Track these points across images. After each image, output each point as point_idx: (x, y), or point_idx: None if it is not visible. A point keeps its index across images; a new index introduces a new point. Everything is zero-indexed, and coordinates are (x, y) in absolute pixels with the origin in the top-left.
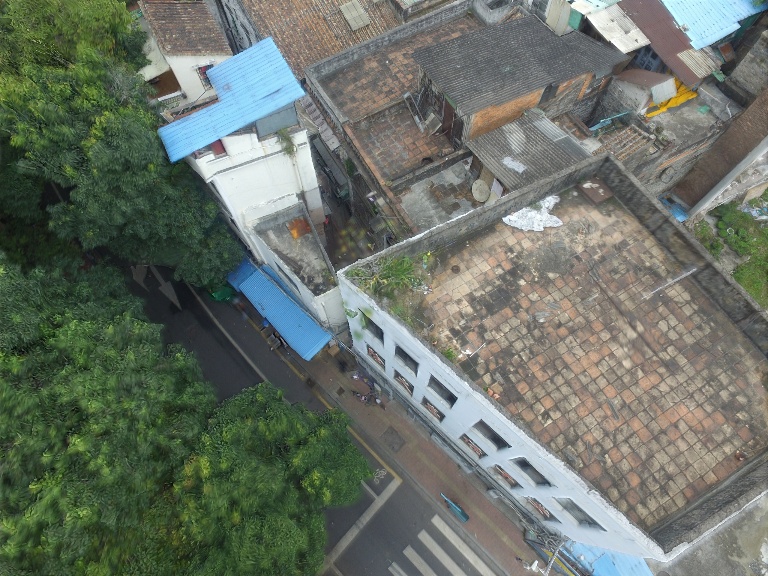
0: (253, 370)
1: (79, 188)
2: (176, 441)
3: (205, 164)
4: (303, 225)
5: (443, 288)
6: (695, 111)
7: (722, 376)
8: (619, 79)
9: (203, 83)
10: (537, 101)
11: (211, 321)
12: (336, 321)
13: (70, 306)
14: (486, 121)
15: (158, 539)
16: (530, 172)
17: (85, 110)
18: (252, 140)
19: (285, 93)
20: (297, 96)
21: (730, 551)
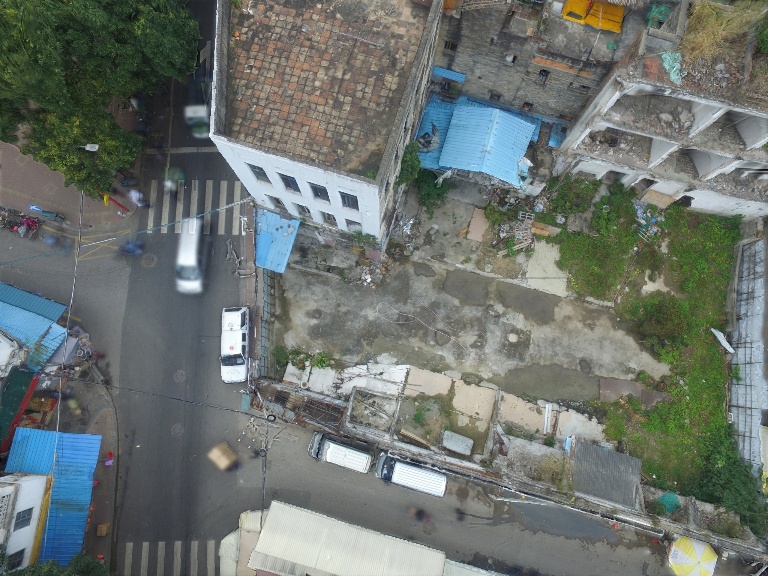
0: None
1: None
2: None
3: None
4: None
5: None
6: (604, 42)
7: (356, 131)
8: None
9: None
10: None
11: None
12: None
13: None
14: None
15: None
16: None
17: None
18: None
19: None
20: None
21: (366, 338)
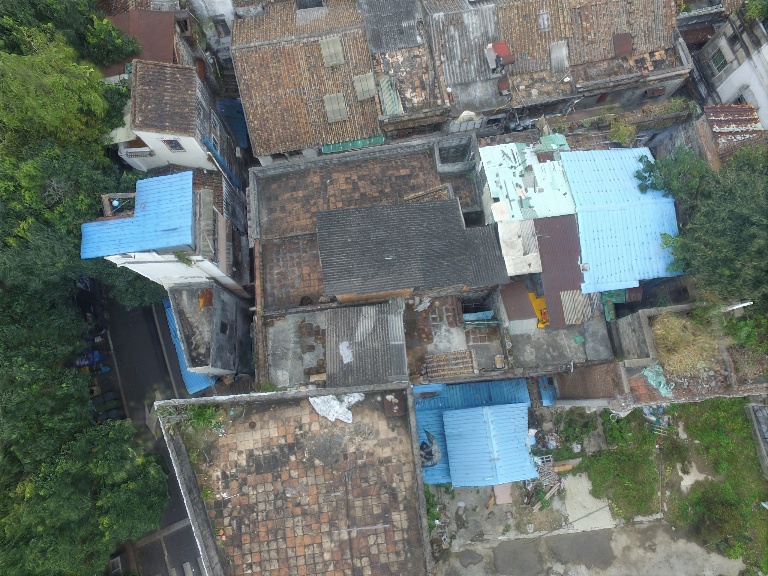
0: (166, 369)
1: None
2: (25, 461)
3: (114, 258)
4: (210, 297)
5: (235, 437)
6: (570, 337)
7: None
8: (500, 292)
9: (169, 148)
10: (410, 290)
11: (152, 314)
12: (221, 373)
13: (5, 318)
14: (354, 296)
15: (4, 512)
16: (352, 366)
17: (18, 211)
18: (152, 254)
19: (178, 235)
20: (185, 242)
21: None
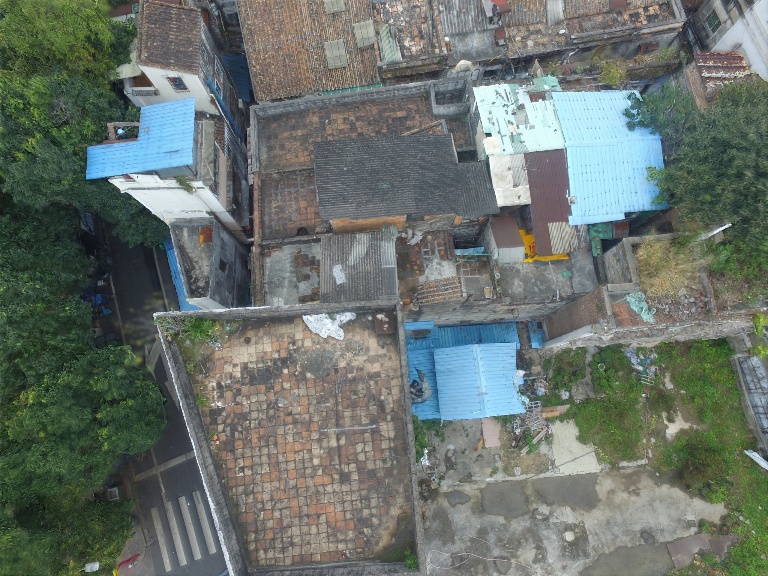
0: None
1: (6, 187)
2: (29, 374)
3: (118, 182)
4: (210, 234)
5: (231, 351)
6: (558, 272)
7: (374, 500)
8: (490, 224)
9: (173, 87)
10: (403, 220)
11: (154, 262)
12: None
13: (11, 244)
14: (348, 223)
15: None
16: (344, 287)
17: (27, 127)
18: (154, 178)
19: (180, 156)
20: (187, 163)
21: None
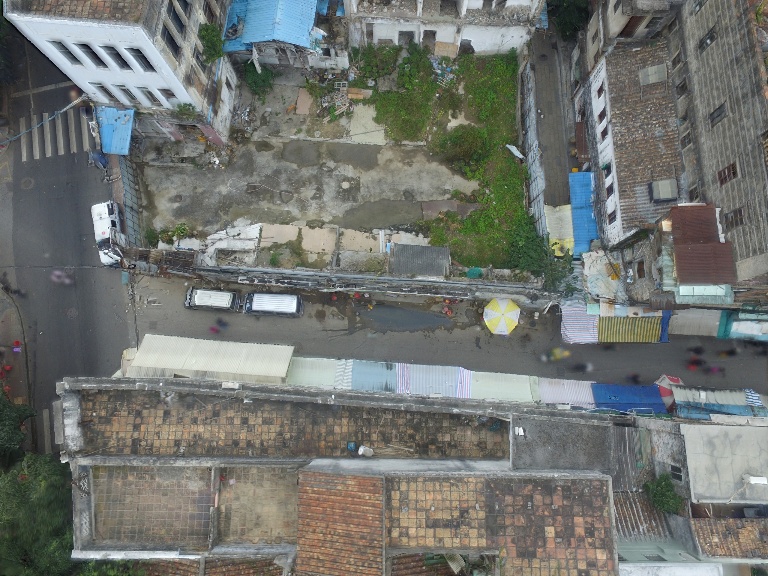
0: None
1: None
2: None
3: None
4: None
5: None
6: None
7: None
8: None
9: None
10: None
11: None
12: None
13: None
14: None
15: None
16: None
17: None
18: None
19: None
20: None
21: (222, 209)
